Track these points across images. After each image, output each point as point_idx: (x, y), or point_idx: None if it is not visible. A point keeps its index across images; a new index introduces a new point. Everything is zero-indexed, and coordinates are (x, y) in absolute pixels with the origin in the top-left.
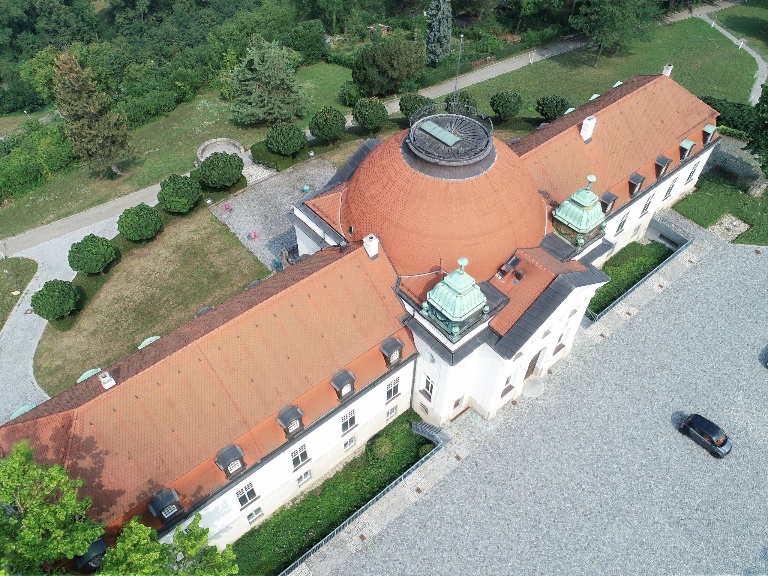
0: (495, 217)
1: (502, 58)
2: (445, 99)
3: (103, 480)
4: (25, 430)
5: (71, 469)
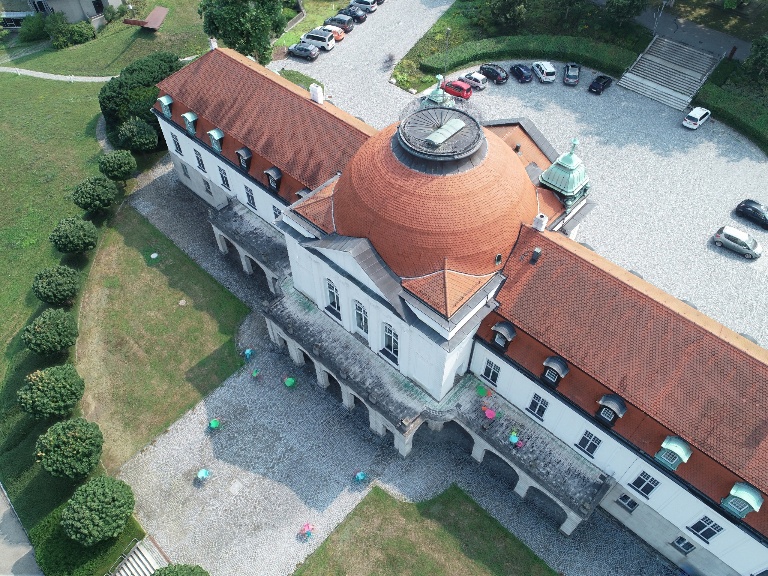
0: None
1: None
2: (50, 295)
3: None
4: None
5: None
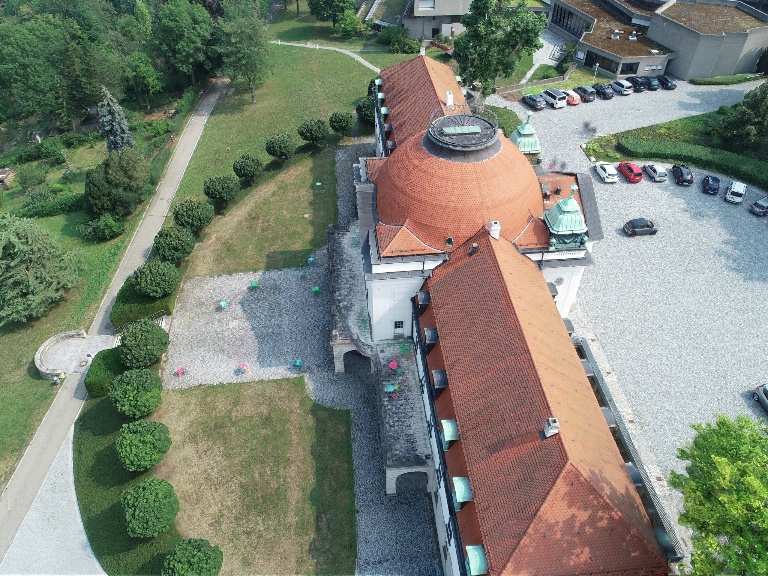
0: (527, 163)
1: (178, 132)
2: (238, 168)
3: (618, 490)
4: (535, 536)
5: (610, 501)
